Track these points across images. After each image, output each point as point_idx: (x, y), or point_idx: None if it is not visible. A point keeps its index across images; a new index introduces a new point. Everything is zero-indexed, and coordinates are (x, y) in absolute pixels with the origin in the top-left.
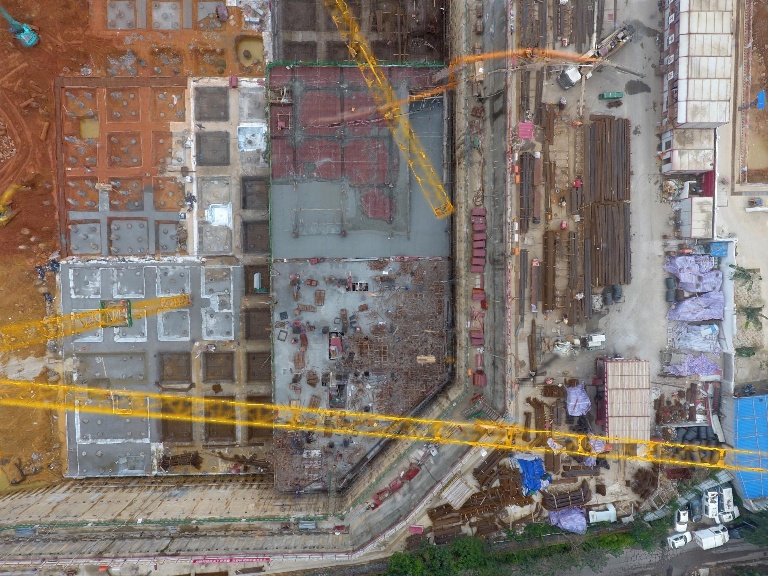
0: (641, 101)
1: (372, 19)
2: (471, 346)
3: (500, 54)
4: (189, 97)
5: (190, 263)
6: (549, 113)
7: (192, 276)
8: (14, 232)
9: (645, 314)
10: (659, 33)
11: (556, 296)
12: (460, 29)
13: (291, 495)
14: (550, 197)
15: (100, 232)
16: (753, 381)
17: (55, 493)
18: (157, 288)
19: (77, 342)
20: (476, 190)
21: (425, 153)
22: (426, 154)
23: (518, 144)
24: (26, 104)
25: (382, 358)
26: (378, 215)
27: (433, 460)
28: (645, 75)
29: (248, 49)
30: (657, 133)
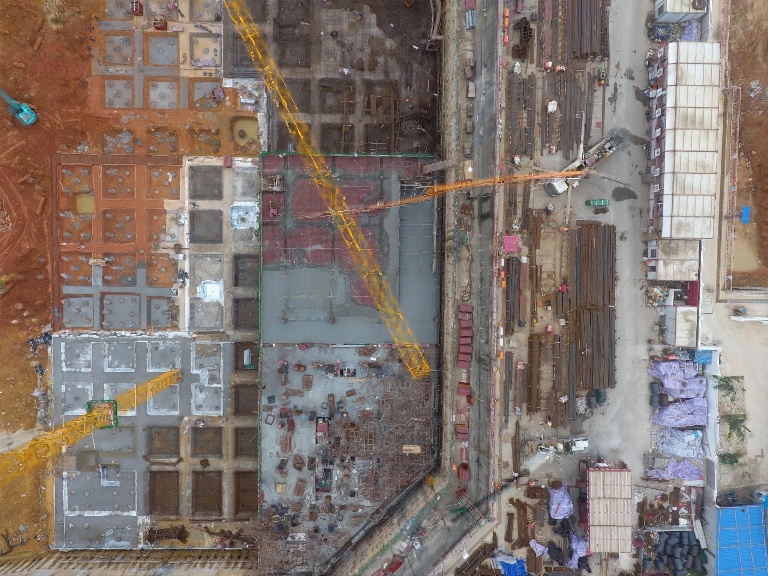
0: (628, 207)
1: (366, 103)
2: (456, 440)
3: (489, 158)
4: (184, 176)
5: (181, 339)
6: (536, 218)
7: (183, 352)
8: (8, 305)
9: (629, 417)
10: (646, 141)
11: (540, 398)
12: (451, 126)
13: None
14: (536, 300)
15: (93, 306)
16: (736, 487)
17: (40, 569)
18: (148, 363)
19: (67, 415)
20: (464, 285)
21: (415, 240)
22: (416, 241)
23: (504, 250)
24: (23, 180)
25: (368, 447)
26: (367, 302)
27: (416, 554)
28: (631, 185)
29: (243, 128)
30: (643, 240)
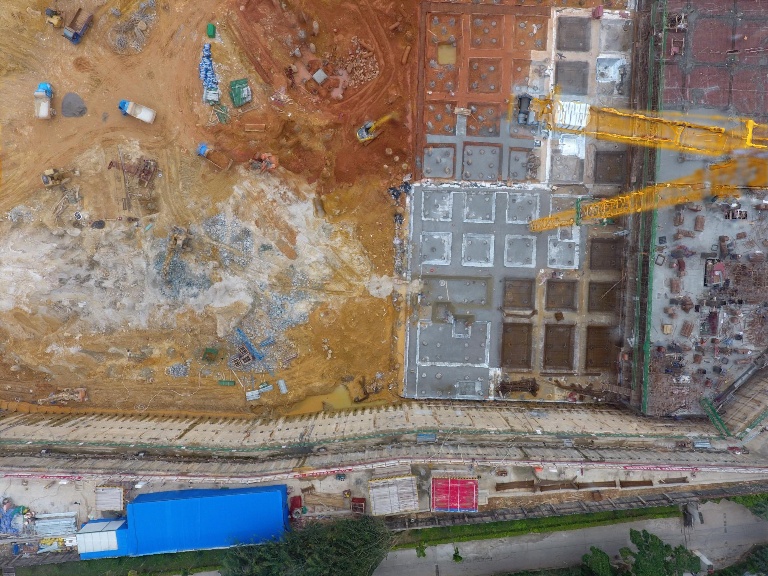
0: None
1: None
2: None
3: None
4: (552, 26)
5: (540, 191)
6: None
7: (542, 203)
8: (372, 153)
9: None
10: None
11: None
12: None
13: (657, 420)
14: None
15: (455, 156)
16: None
17: (414, 409)
18: (506, 214)
19: (425, 264)
20: None
21: None
22: None
23: None
24: (394, 27)
25: None
26: None
27: None
28: None
29: None
30: None
